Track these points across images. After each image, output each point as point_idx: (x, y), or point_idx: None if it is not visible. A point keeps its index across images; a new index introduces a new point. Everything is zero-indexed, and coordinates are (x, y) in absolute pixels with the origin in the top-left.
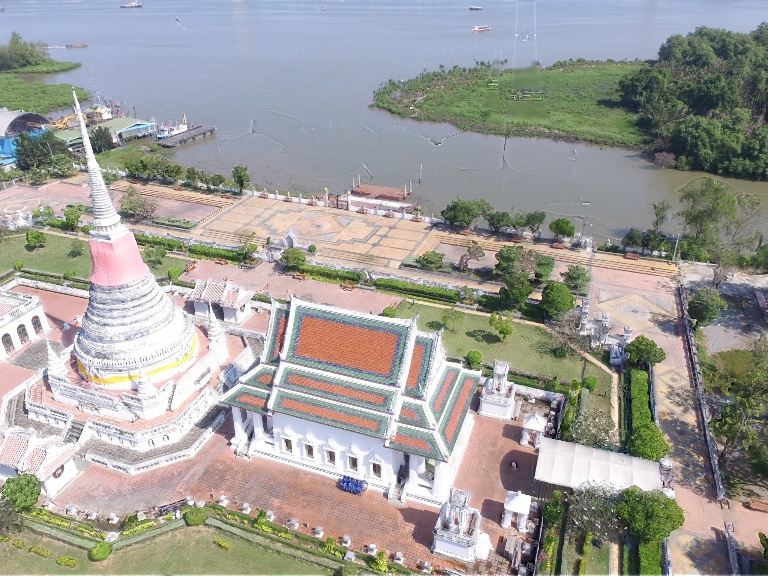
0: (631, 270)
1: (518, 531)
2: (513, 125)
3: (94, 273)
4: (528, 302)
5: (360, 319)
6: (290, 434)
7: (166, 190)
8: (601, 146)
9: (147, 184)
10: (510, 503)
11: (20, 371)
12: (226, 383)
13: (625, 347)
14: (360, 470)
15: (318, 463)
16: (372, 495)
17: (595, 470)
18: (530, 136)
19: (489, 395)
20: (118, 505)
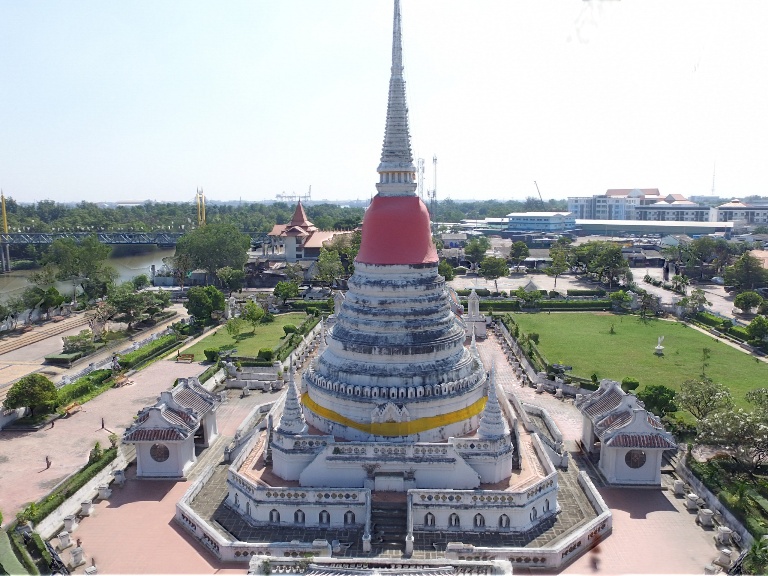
0: None
1: None
2: None
3: None
4: None
5: None
6: None
7: None
8: None
9: None
10: None
11: None
12: None
13: (282, 294)
14: None
15: None
16: None
17: None
18: None
19: None
20: None
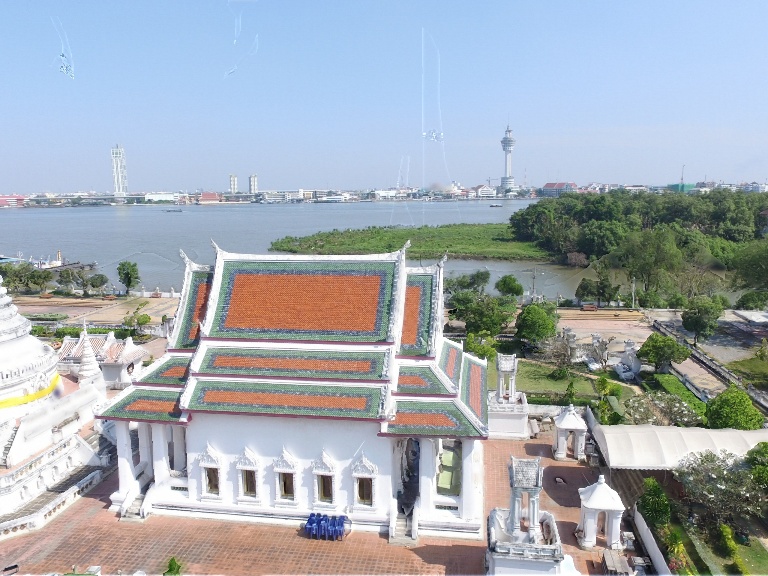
0: (594, 319)
1: (611, 549)
2: (427, 229)
3: None
4: (499, 340)
5: (322, 264)
6: (216, 456)
7: (29, 299)
8: (510, 260)
9: None
10: (592, 498)
11: None
12: (104, 434)
13: (638, 351)
14: (337, 499)
15: (264, 504)
16: (361, 538)
17: (691, 441)
18: (439, 258)
19: (496, 404)
20: None
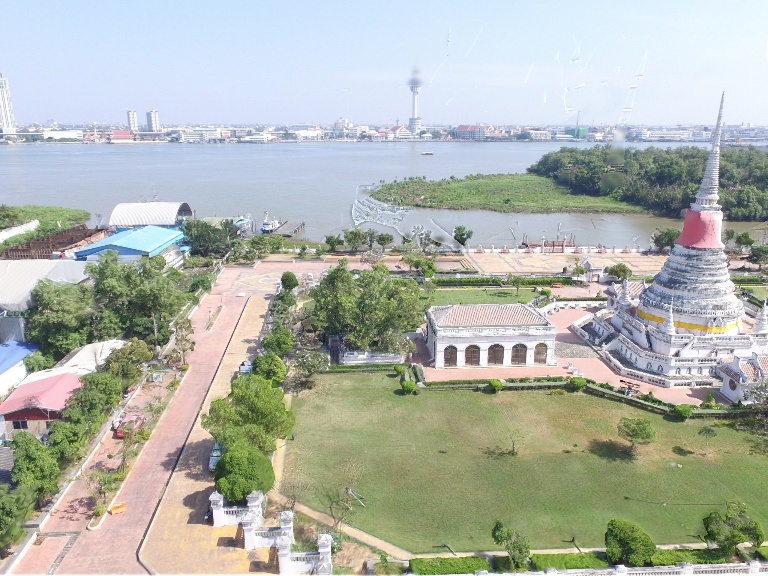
0: None
1: None
2: None
3: (703, 240)
4: None
5: None
6: None
7: None
8: (621, 214)
9: (356, 255)
10: None
11: (580, 360)
12: None
13: None
14: None
15: None
16: None
17: None
18: (562, 212)
19: None
20: None
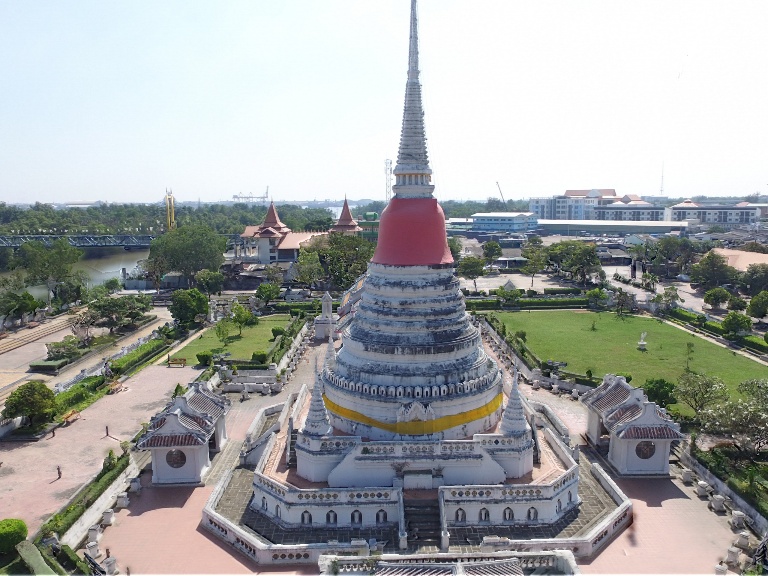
0: None
1: None
2: None
3: None
4: None
5: None
6: None
7: None
8: None
9: None
10: None
11: None
12: None
13: (264, 296)
14: None
15: None
16: None
17: None
18: None
19: None
20: (581, 408)
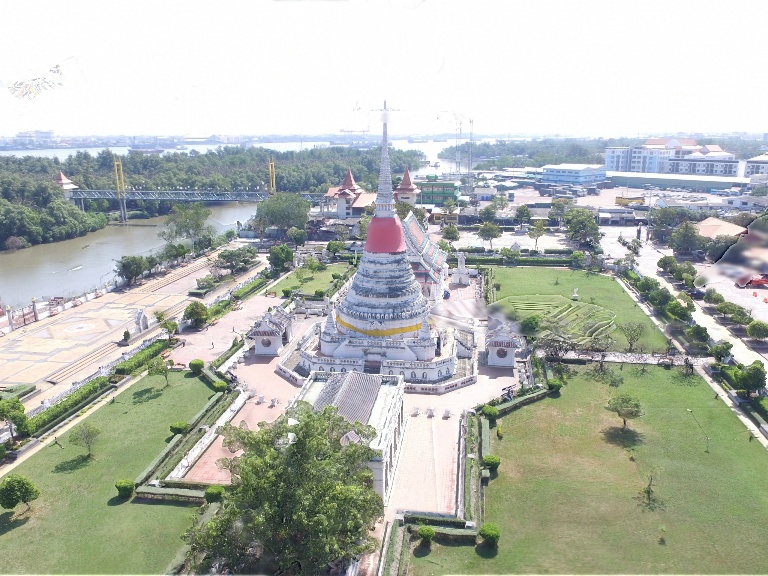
0: None
1: None
2: None
3: None
4: None
5: None
6: None
7: None
8: None
9: None
10: None
11: None
12: None
13: (332, 249)
14: None
15: None
16: None
17: None
18: None
19: None
20: None
